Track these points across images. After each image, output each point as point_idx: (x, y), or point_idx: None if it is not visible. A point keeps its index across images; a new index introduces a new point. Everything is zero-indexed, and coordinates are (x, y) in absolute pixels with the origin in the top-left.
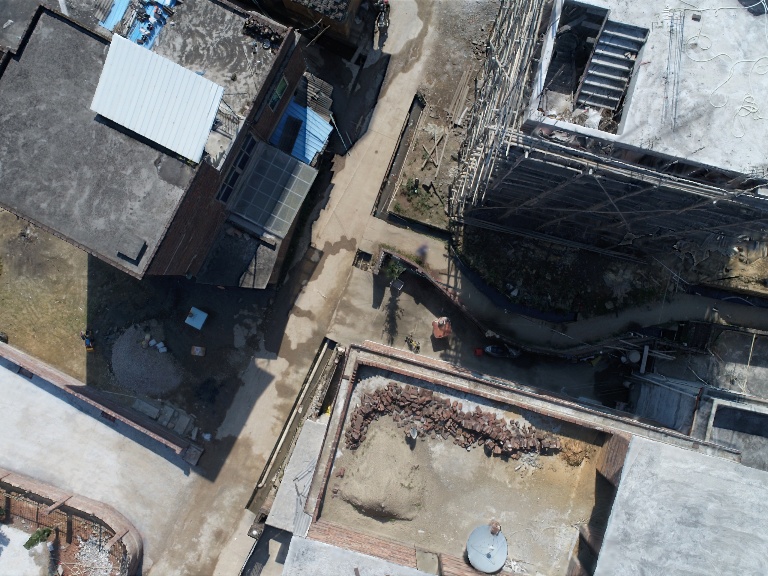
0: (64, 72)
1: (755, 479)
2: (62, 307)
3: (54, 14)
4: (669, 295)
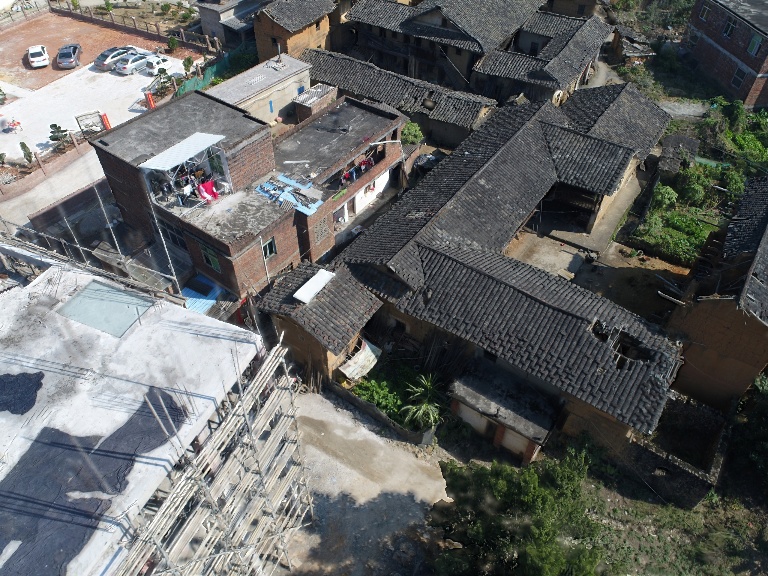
0: (227, 129)
1: None
2: None
3: None
4: None
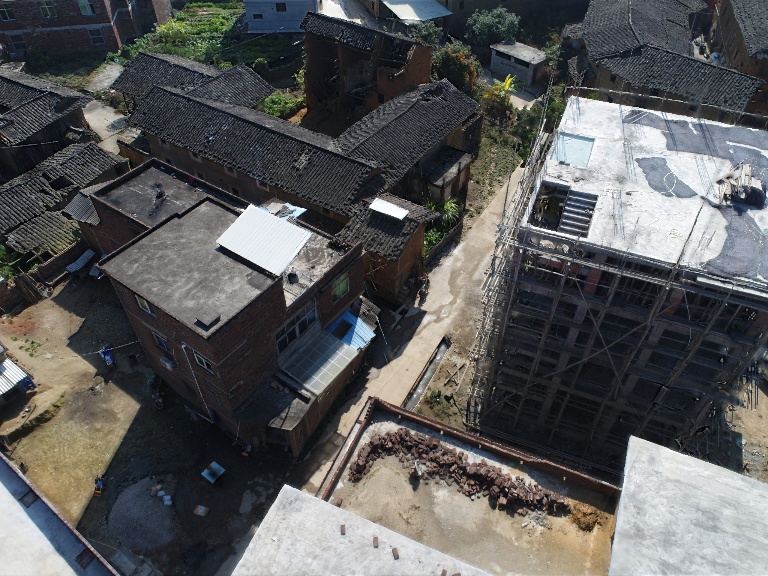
0: (206, 226)
1: (767, 492)
2: (92, 451)
3: (214, 202)
4: None
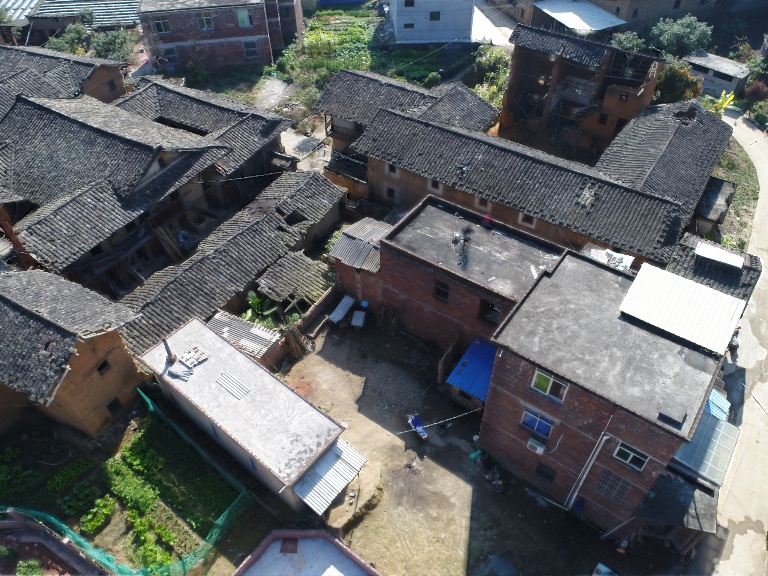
0: (588, 288)
1: None
2: (440, 546)
3: (577, 256)
4: None
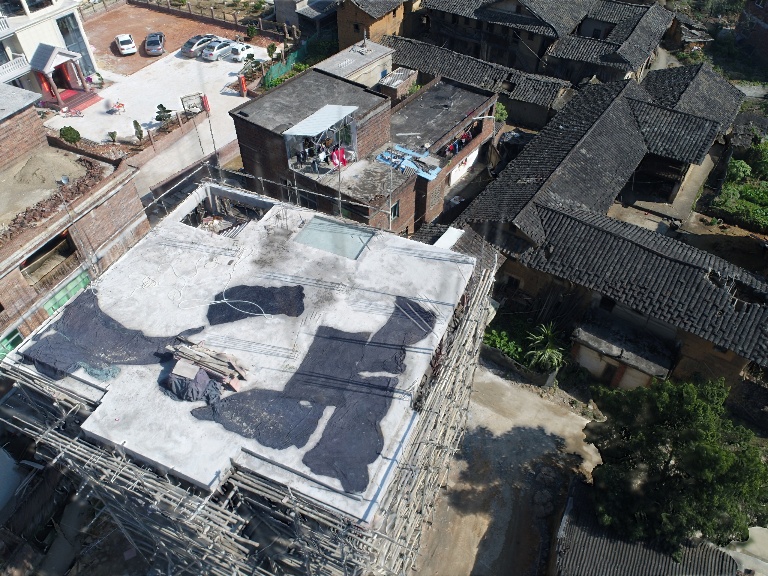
0: (352, 102)
1: None
2: None
3: None
4: (83, 537)
